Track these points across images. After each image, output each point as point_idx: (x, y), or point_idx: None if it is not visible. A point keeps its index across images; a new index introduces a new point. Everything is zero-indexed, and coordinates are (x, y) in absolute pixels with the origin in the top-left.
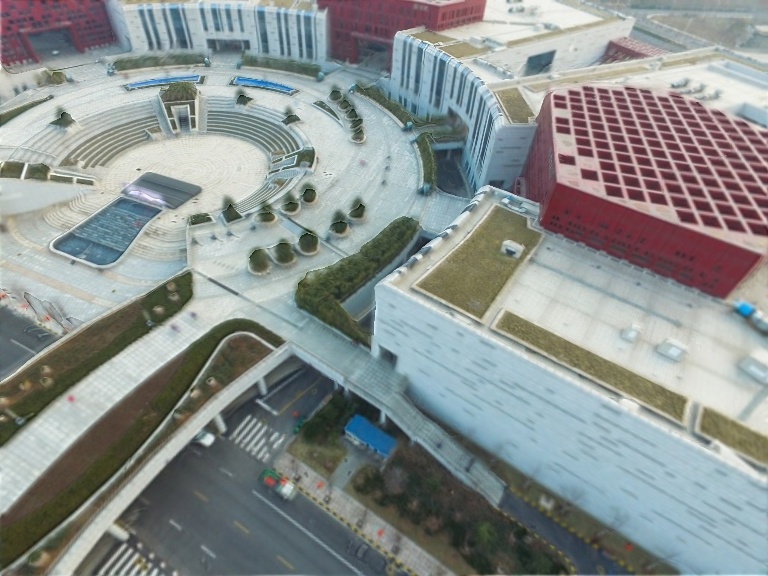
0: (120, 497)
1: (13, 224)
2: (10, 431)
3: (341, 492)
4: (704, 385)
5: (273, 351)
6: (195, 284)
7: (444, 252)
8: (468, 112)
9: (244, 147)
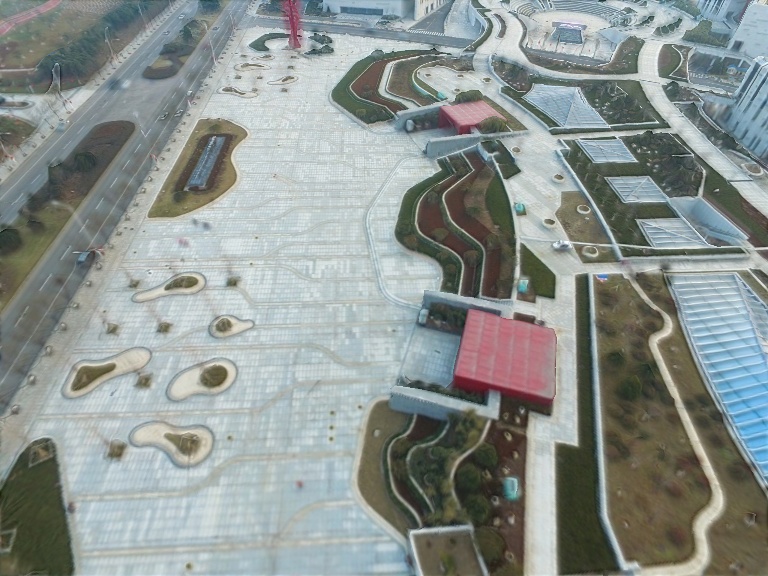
0: None
1: None
2: (636, 56)
3: None
4: None
5: None
6: None
7: (762, 2)
8: None
9: None
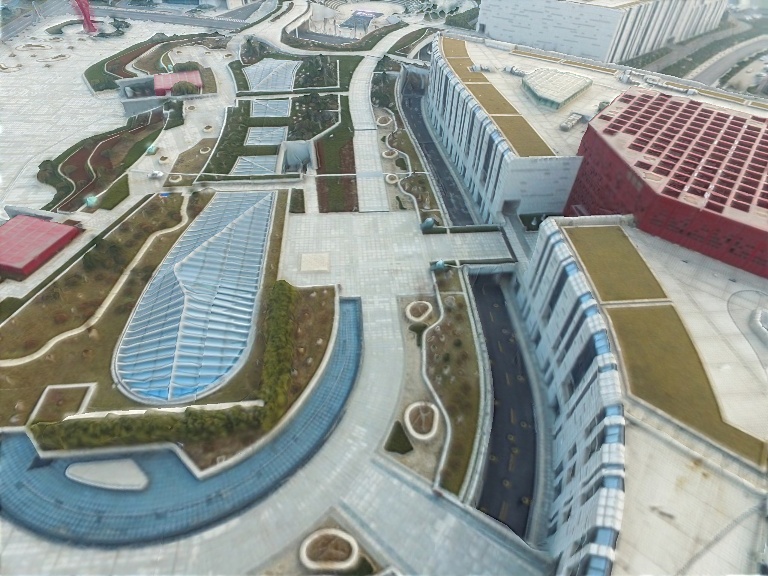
0: (421, 43)
1: (317, 23)
2: None
3: None
4: (572, 0)
5: (445, 30)
6: None
7: None
8: None
9: (390, 5)
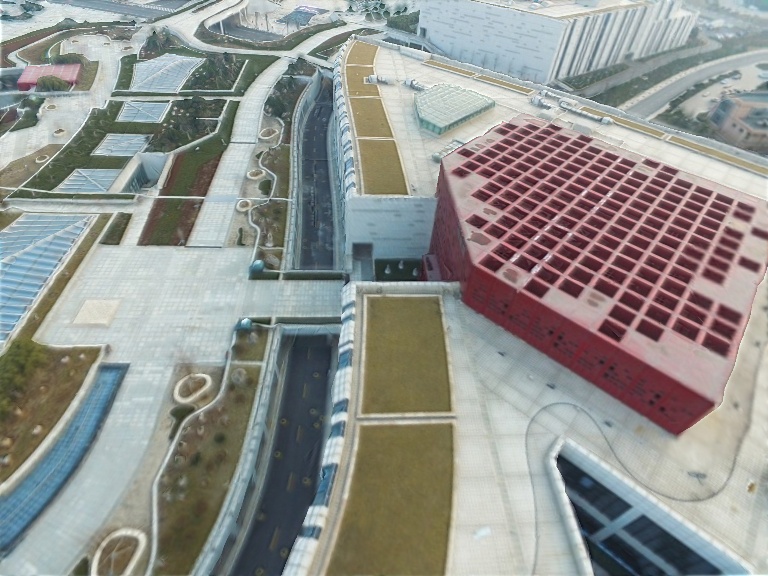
0: None
1: None
2: (309, 36)
3: None
4: None
5: None
6: (346, 22)
7: None
8: None
9: (341, 1)
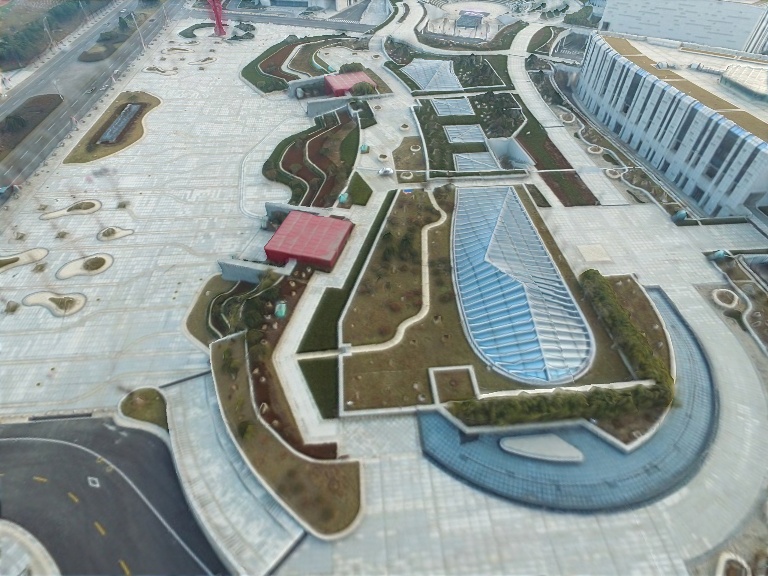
0: None
1: None
2: (514, 36)
3: None
4: None
5: None
6: None
7: None
8: None
9: (490, 4)
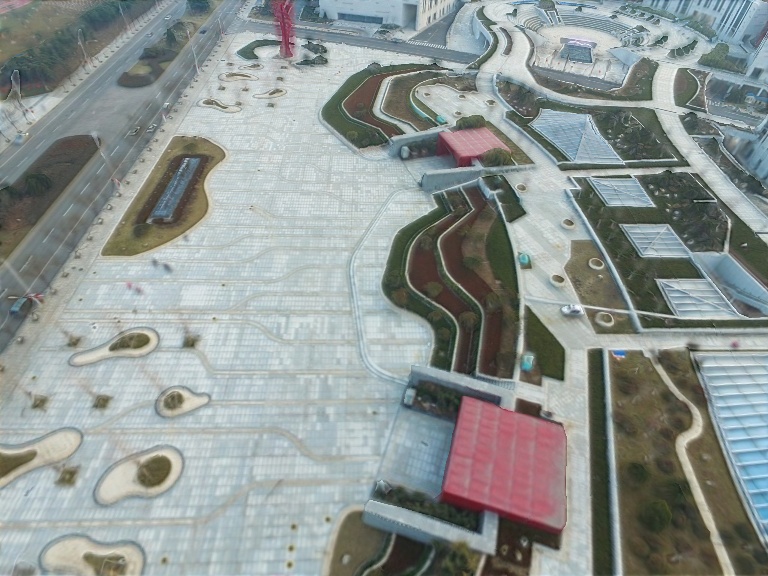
0: None
1: None
2: (651, 81)
3: (754, 112)
4: None
5: (710, 73)
6: None
7: None
8: (716, 9)
9: (591, 31)
